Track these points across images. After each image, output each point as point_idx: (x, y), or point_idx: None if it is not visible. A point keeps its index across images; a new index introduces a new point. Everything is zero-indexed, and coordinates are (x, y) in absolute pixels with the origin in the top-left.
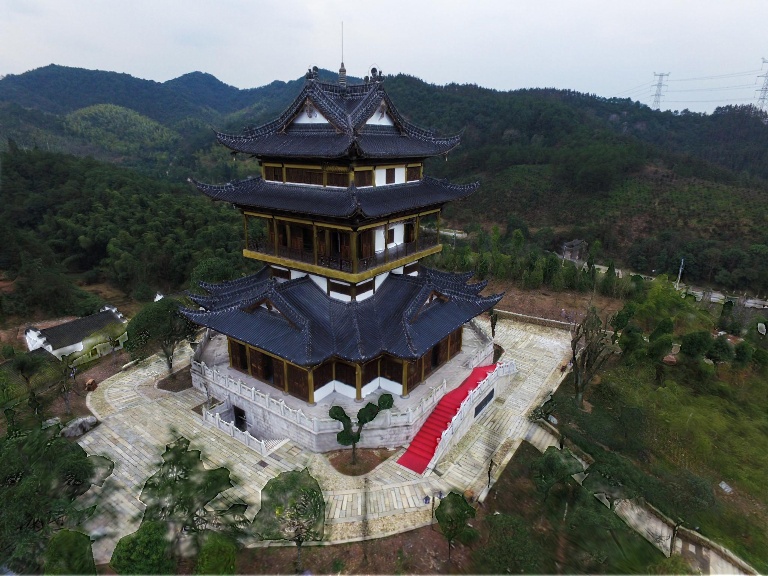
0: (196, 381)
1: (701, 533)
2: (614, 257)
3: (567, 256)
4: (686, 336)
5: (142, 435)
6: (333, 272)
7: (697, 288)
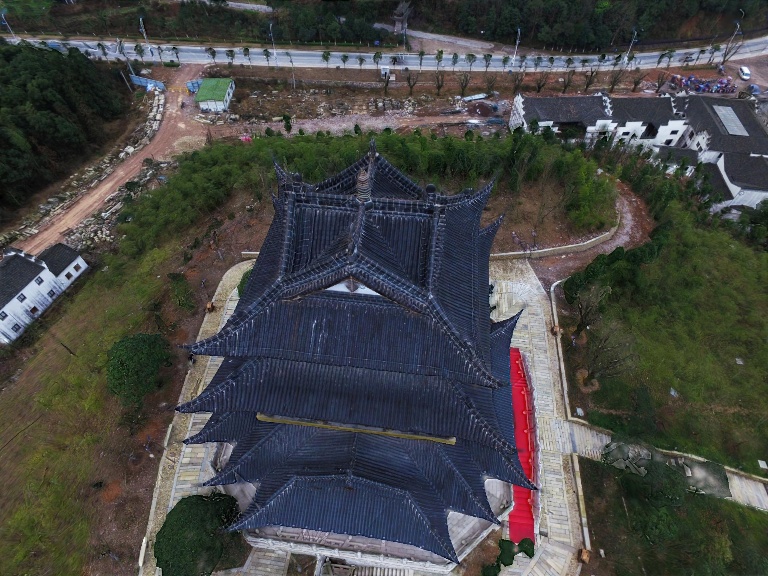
0: (259, 546)
1: (678, 451)
2: (444, 20)
3: (398, 28)
4: (630, 255)
5: None
6: (421, 438)
7: (523, 50)
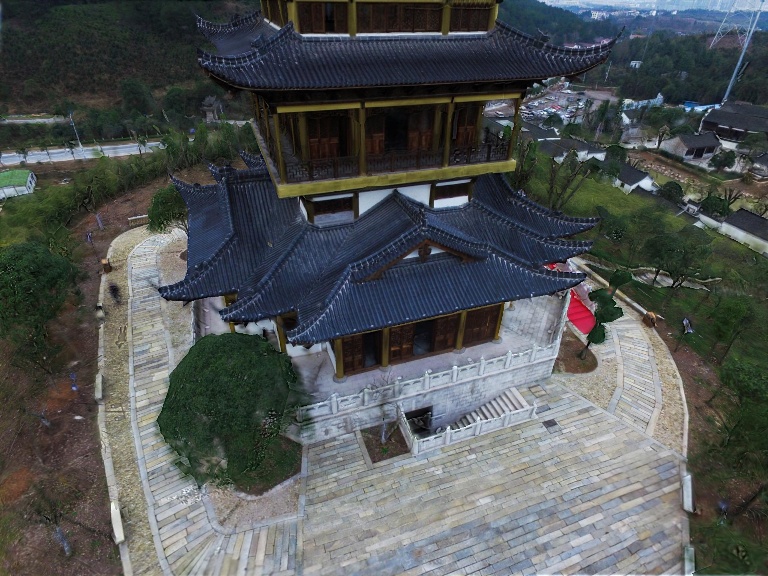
0: (314, 433)
1: (642, 266)
2: None
3: (210, 118)
4: None
5: (404, 543)
6: (481, 167)
7: None
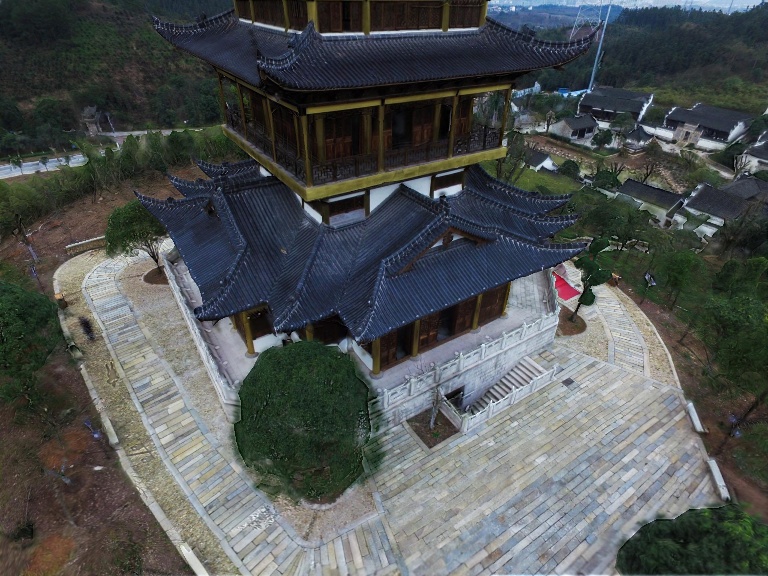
0: None
1: None
2: (140, 118)
3: (94, 130)
4: None
5: (487, 513)
6: (480, 155)
7: None
